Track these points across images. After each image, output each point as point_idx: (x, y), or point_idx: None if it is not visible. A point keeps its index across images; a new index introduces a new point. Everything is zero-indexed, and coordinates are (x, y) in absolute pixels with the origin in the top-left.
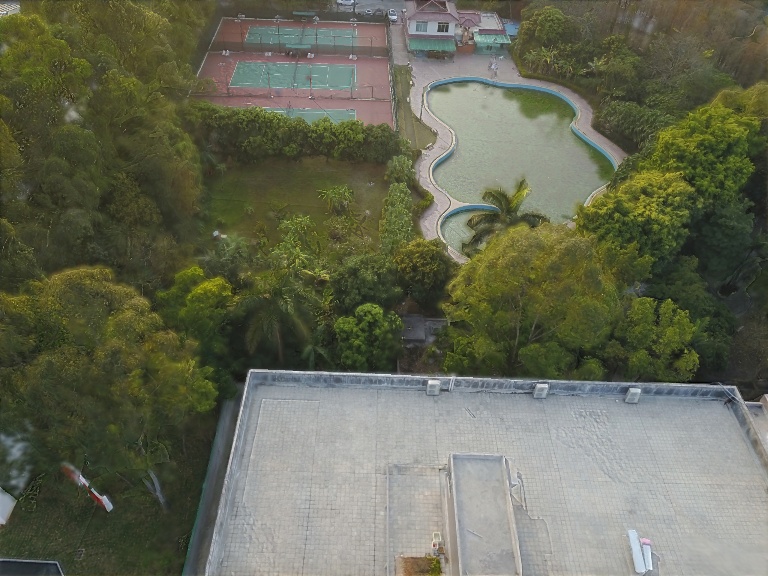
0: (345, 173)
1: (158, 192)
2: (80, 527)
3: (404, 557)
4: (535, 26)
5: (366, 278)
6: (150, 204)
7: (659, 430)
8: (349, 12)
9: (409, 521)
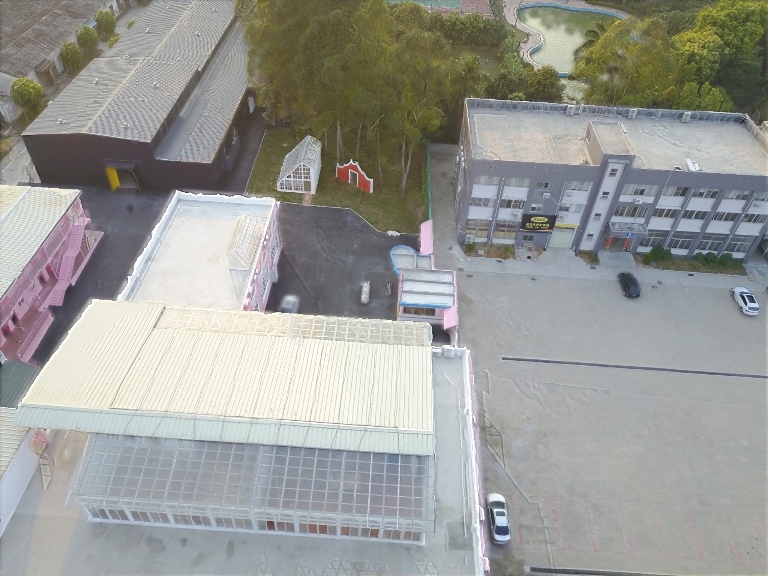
0: None
1: None
2: (357, 198)
3: (568, 163)
4: None
5: (513, 79)
6: None
7: (701, 132)
8: None
9: (568, 154)
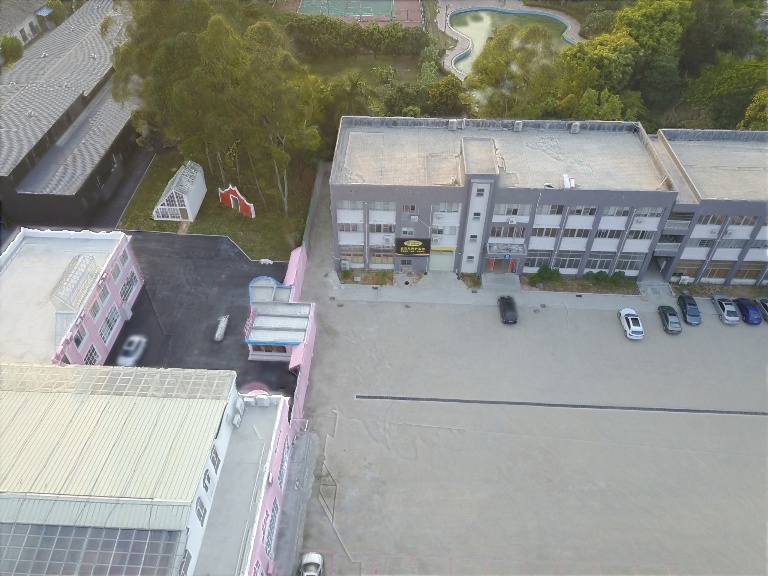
0: (389, 64)
1: None
2: (237, 224)
3: (436, 184)
4: None
5: (409, 92)
6: None
7: (590, 143)
8: None
9: (438, 173)
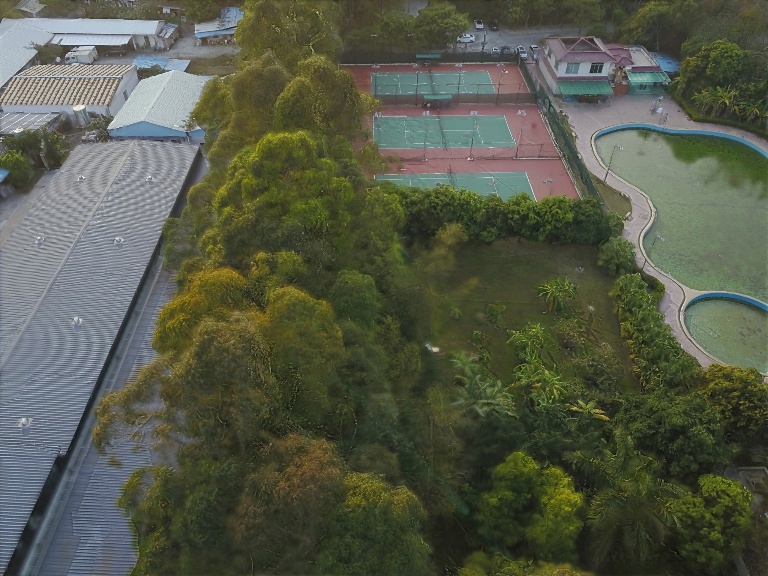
0: (545, 256)
1: (419, 332)
2: None
3: None
4: (705, 63)
5: (705, 441)
6: (417, 351)
7: None
8: (477, 52)
9: None
